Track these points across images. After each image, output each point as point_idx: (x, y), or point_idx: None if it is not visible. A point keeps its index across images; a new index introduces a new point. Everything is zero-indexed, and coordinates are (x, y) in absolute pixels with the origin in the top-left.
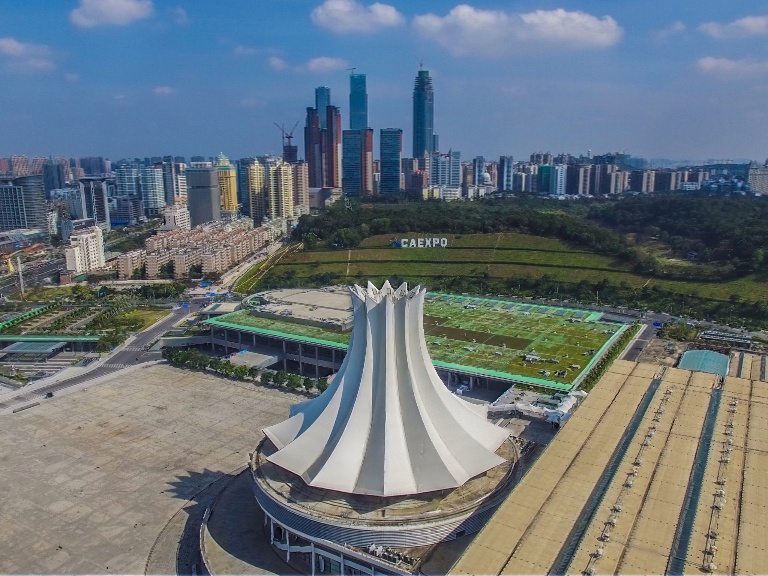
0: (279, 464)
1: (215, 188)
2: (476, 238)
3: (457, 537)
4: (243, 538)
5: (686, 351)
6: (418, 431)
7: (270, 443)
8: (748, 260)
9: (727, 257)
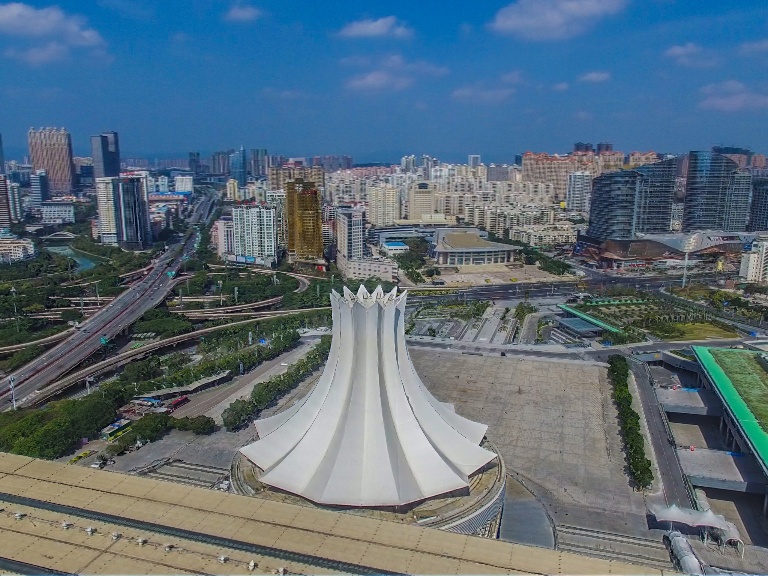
0: None
1: None
2: None
3: None
4: None
5: None
6: None
7: None
8: None
9: None
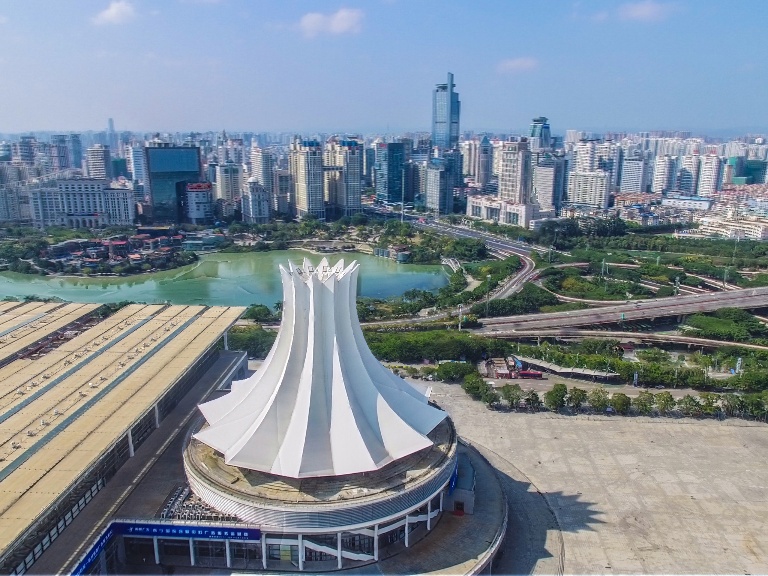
0: None
1: None
2: None
3: None
4: None
5: None
6: None
7: None
8: None
9: None
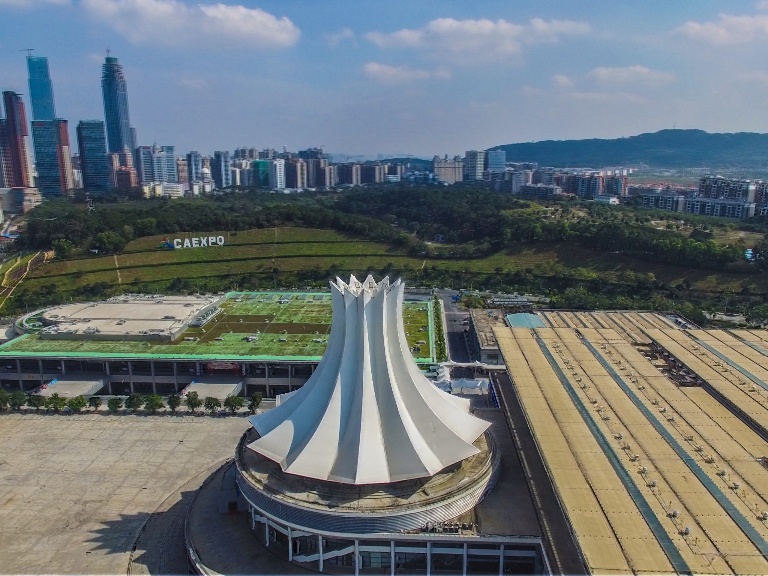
0: (301, 474)
1: None
2: (253, 234)
3: (485, 497)
4: (256, 565)
5: (507, 316)
6: (424, 412)
7: (251, 460)
8: (497, 238)
9: (471, 237)
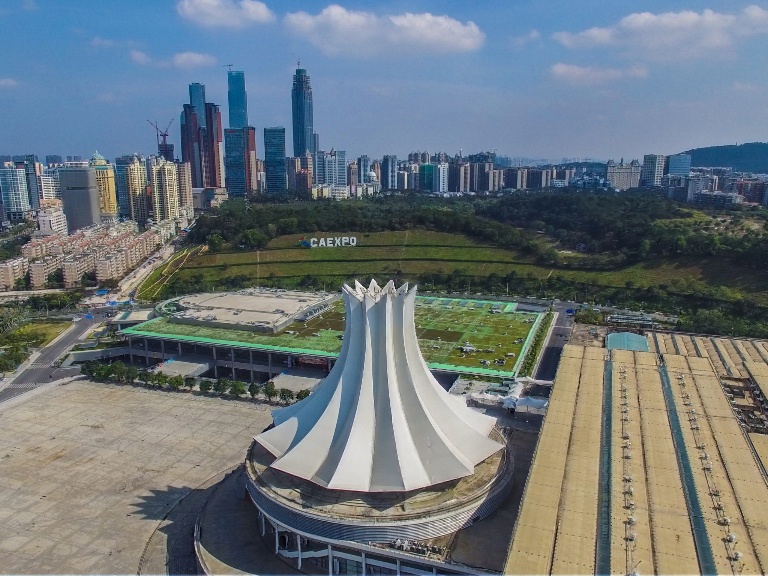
0: (286, 471)
1: (93, 189)
2: (384, 236)
3: (473, 523)
4: (244, 551)
5: (609, 334)
6: (423, 425)
7: (260, 451)
8: (636, 250)
9: (613, 247)
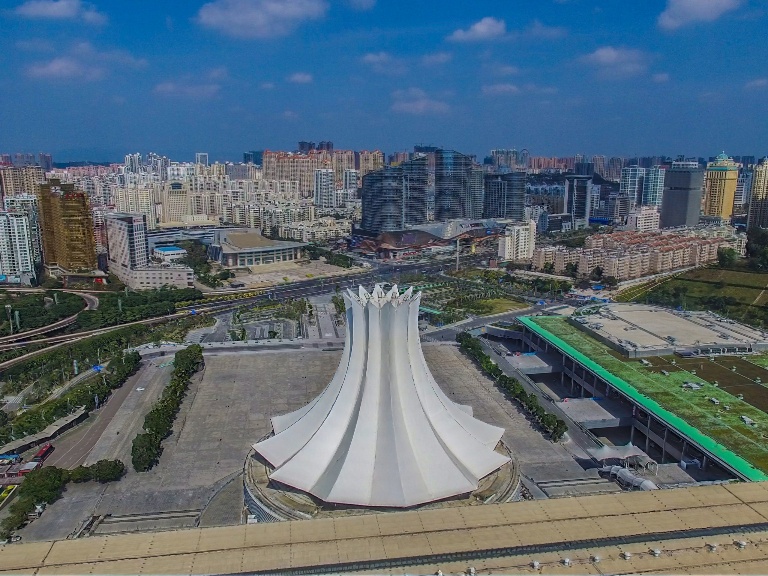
0: (274, 425)
1: (696, 191)
2: None
3: None
4: None
5: None
6: (348, 438)
7: None
8: None
9: None
